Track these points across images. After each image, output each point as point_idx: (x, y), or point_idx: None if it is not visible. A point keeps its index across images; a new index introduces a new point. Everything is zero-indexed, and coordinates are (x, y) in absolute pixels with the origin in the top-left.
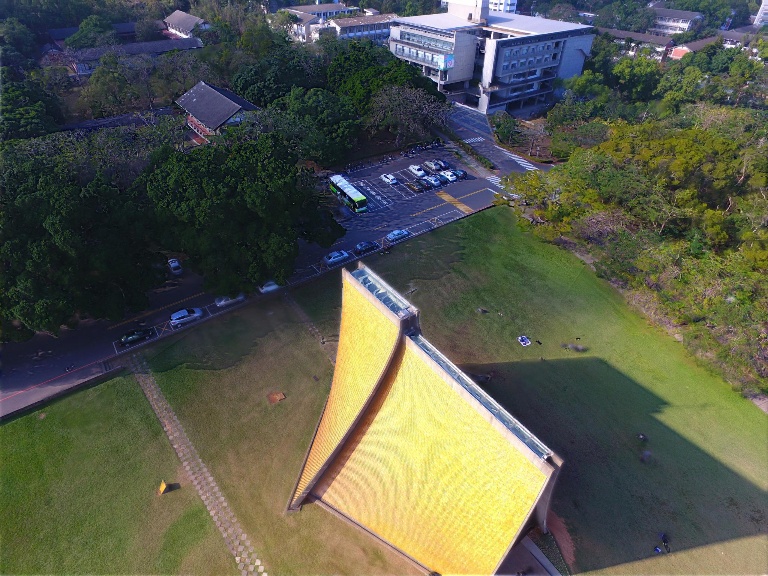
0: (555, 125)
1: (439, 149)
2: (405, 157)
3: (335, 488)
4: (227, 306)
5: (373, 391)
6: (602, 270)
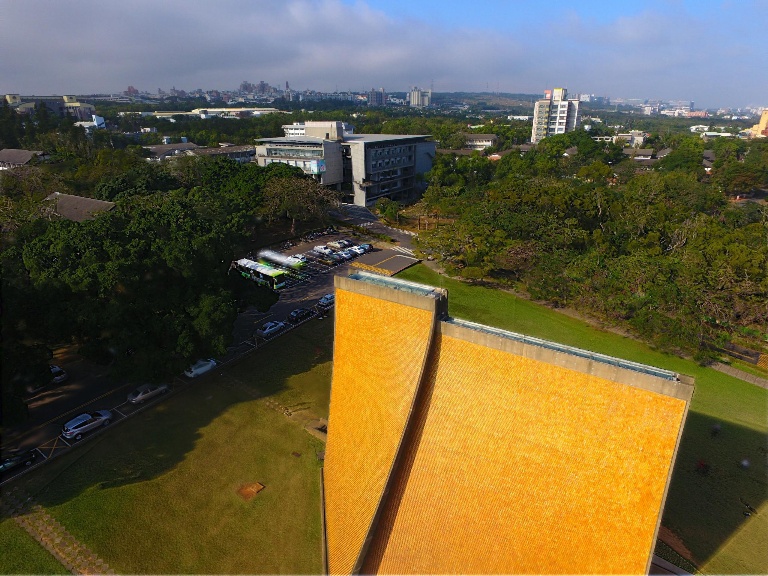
0: (431, 206)
1: (335, 234)
2: (305, 242)
3: (387, 569)
4: (146, 401)
5: (413, 406)
6: (538, 291)
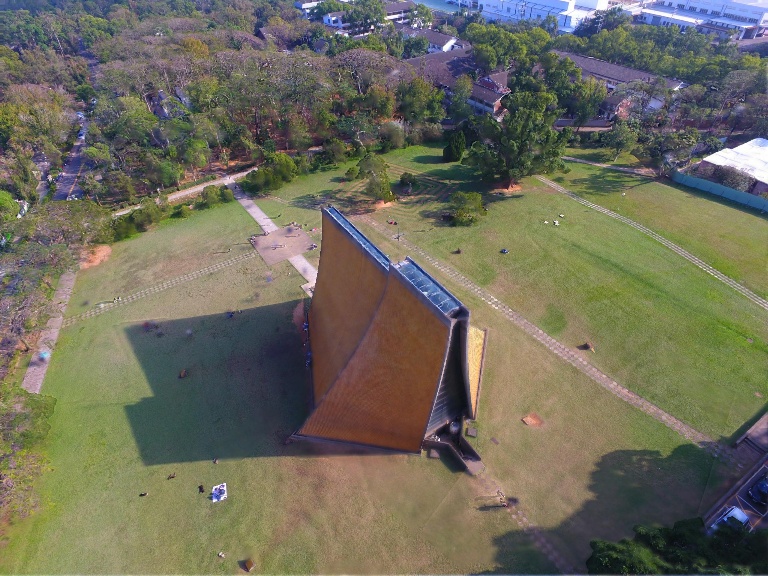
0: None
1: None
2: None
3: None
4: None
5: None
6: None
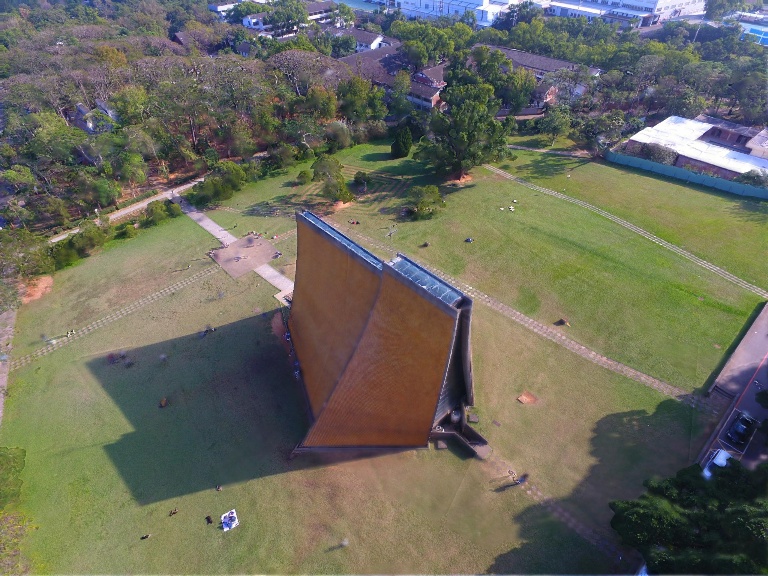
0: None
1: None
2: None
3: None
4: None
5: None
6: None
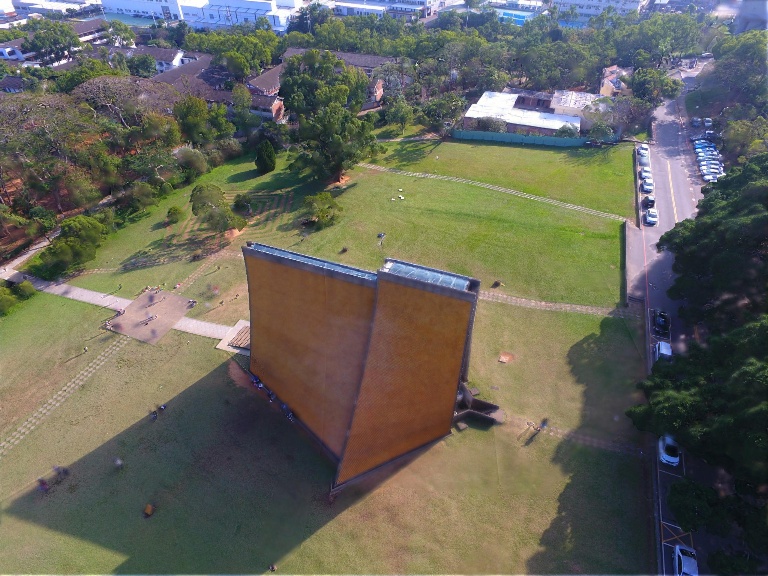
0: None
1: None
2: None
3: None
4: None
5: None
6: None
